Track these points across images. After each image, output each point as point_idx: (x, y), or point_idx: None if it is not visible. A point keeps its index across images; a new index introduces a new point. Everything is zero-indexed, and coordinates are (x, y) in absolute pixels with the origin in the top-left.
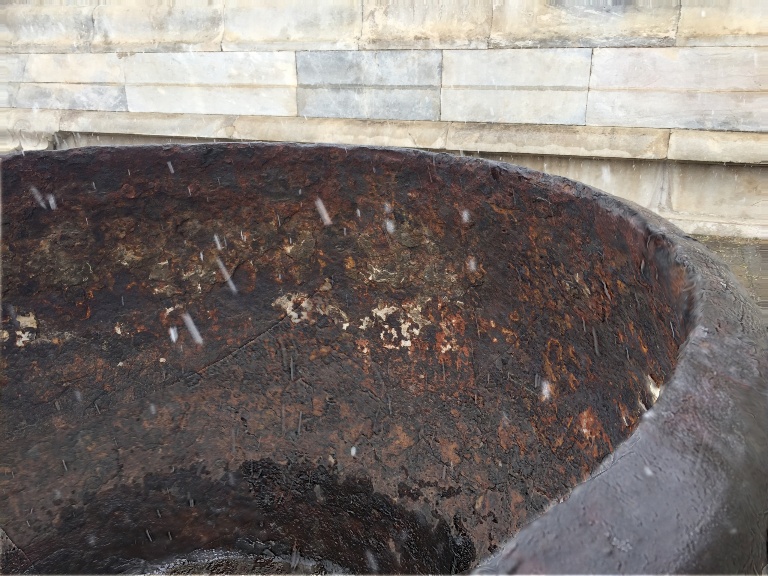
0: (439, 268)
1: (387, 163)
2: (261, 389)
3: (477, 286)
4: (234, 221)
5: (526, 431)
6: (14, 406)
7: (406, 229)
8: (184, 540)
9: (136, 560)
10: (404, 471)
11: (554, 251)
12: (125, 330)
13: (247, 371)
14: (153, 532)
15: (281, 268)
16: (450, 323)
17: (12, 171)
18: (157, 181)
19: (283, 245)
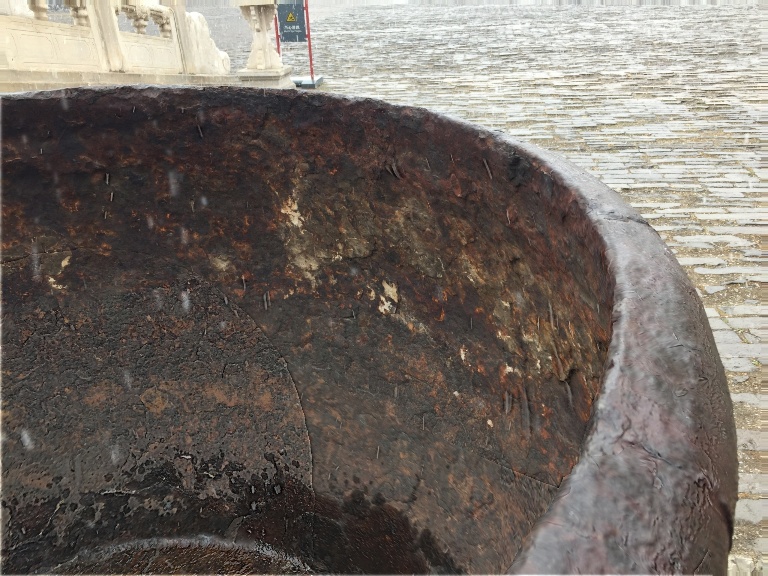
0: None
1: None
2: None
3: None
4: (561, 297)
5: None
6: (365, 366)
7: None
8: None
9: None
10: None
11: None
12: (468, 359)
13: None
14: None
15: None
16: None
17: (356, 119)
18: (479, 183)
19: None
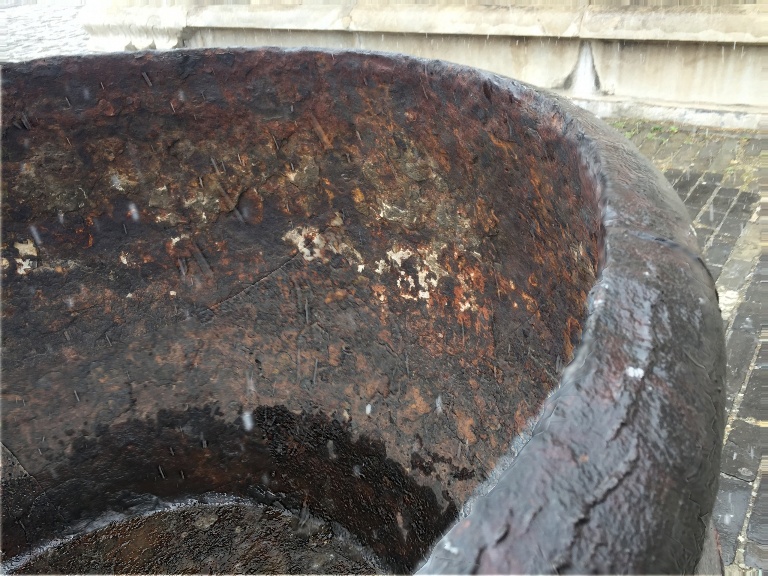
0: (451, 209)
1: (377, 72)
2: (276, 331)
3: (492, 236)
4: (229, 142)
5: None
6: (22, 334)
7: (410, 158)
8: (197, 480)
9: (148, 496)
10: (418, 440)
11: (558, 205)
12: (131, 260)
13: (261, 310)
14: (166, 469)
15: (288, 198)
16: (468, 277)
17: None
18: (135, 96)
19: (285, 171)
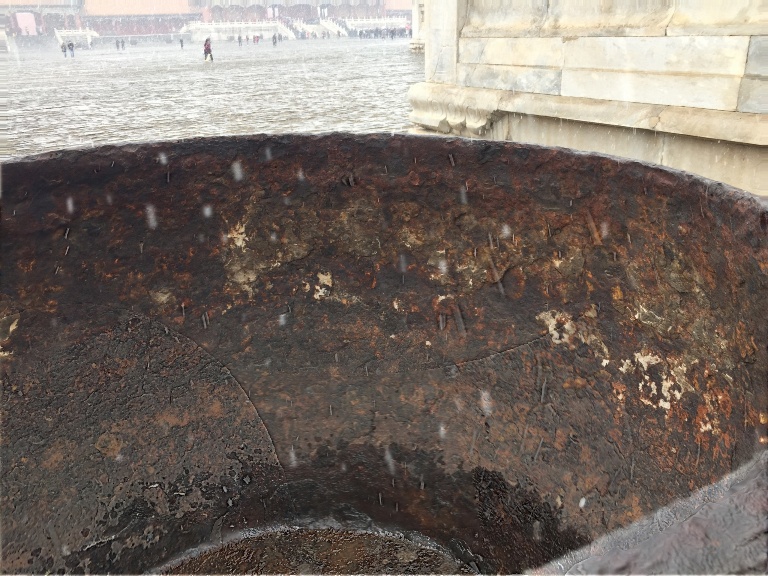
0: (709, 326)
1: (658, 185)
2: (510, 401)
3: (748, 363)
4: (507, 223)
5: None
6: (304, 347)
7: (676, 269)
8: (407, 517)
9: (364, 515)
10: None
11: None
12: (401, 306)
13: (501, 378)
14: (384, 497)
15: (549, 281)
16: (715, 398)
17: (322, 148)
18: (439, 172)
19: (552, 257)
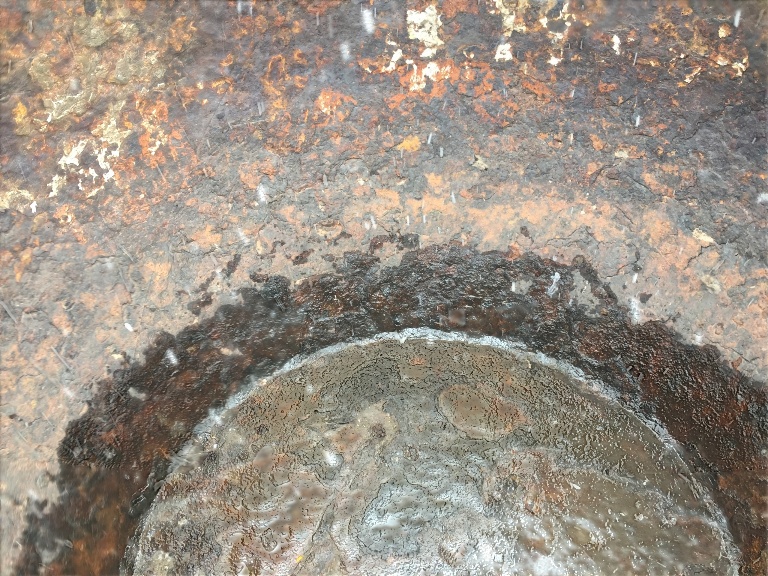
0: (135, 55)
1: None
2: None
3: (182, 53)
4: None
5: (266, 158)
6: None
7: (97, 21)
8: None
9: None
10: (183, 294)
11: None
12: None
13: None
14: None
15: None
16: (152, 116)
17: None
18: None
19: None
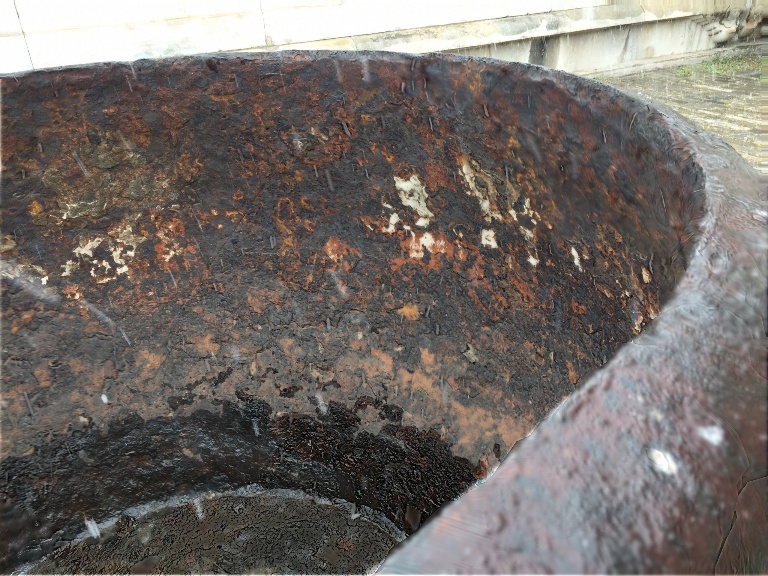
0: (147, 179)
1: (73, 83)
2: None
3: (193, 182)
4: None
5: (275, 288)
6: None
7: (103, 150)
8: None
9: None
10: (167, 387)
11: (283, 118)
12: None
13: None
14: None
15: None
16: (168, 230)
17: None
18: None
19: None
